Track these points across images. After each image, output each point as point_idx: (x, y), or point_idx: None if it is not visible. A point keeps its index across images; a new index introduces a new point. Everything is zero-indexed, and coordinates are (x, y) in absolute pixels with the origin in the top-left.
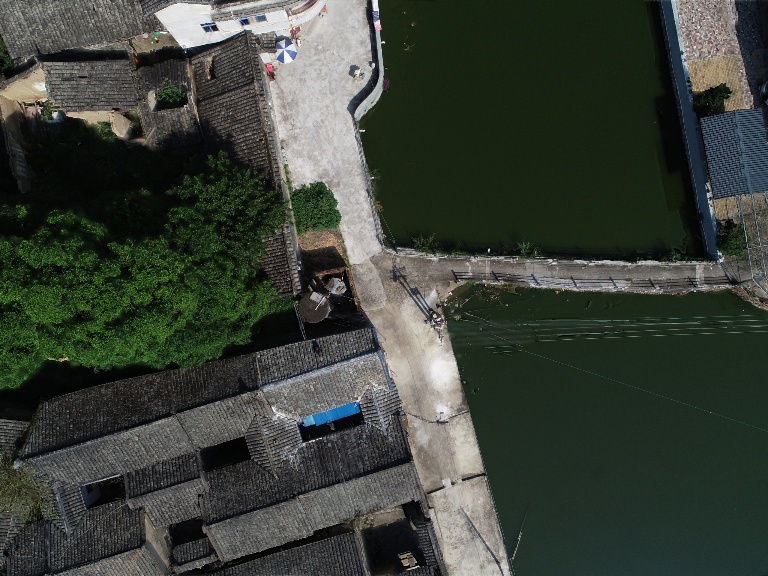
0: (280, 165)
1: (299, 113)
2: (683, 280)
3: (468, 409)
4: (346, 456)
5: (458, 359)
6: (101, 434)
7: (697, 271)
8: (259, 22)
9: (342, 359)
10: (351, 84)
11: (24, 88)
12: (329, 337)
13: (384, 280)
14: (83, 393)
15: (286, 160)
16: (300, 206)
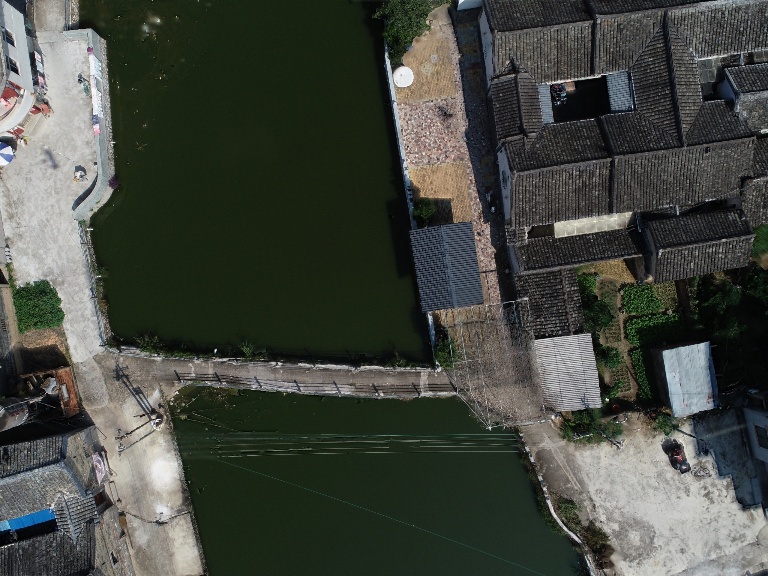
0: None
1: (24, 211)
2: (407, 386)
3: (189, 510)
4: (33, 564)
5: (186, 458)
6: None
7: (421, 378)
8: None
9: (27, 468)
10: (76, 184)
11: None
12: (21, 444)
13: (107, 379)
14: None
15: (9, 258)
16: (22, 304)
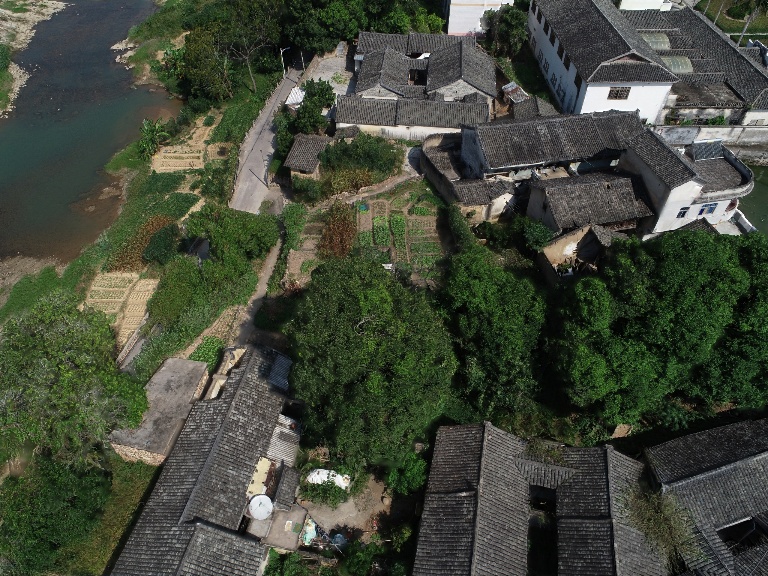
0: None
1: None
2: None
3: None
4: None
5: None
6: (730, 462)
7: None
8: (707, 214)
9: None
10: None
11: (560, 248)
12: None
13: None
14: (680, 441)
15: None
16: None
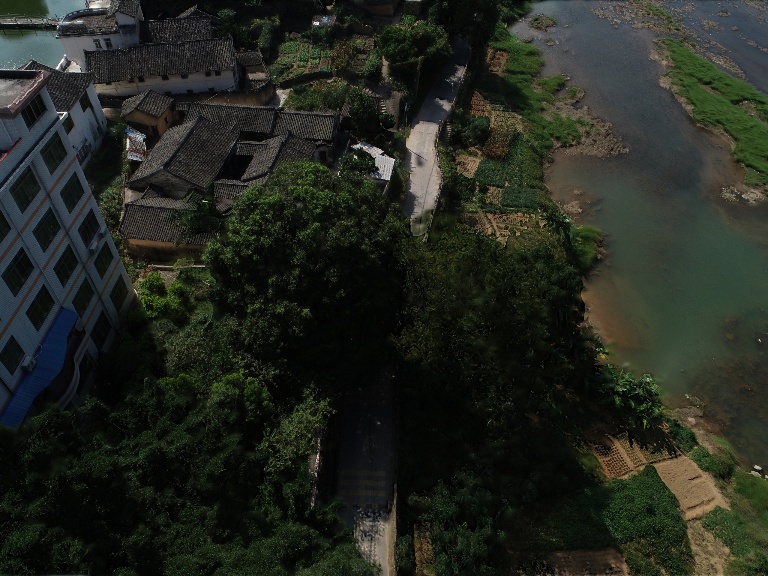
0: None
1: None
2: None
3: None
4: None
5: None
6: None
7: None
8: None
9: None
10: None
11: None
12: None
13: None
14: None
15: None
16: None
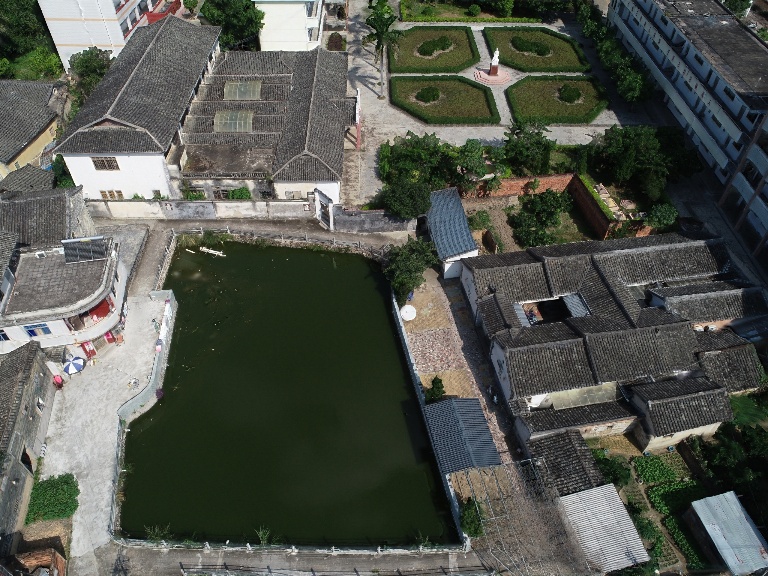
0: (30, 452)
1: (73, 415)
2: (435, 571)
3: None
4: None
5: None
6: None
7: (450, 560)
8: (46, 334)
9: None
10: (127, 392)
11: None
12: None
13: (102, 575)
14: None
15: (43, 453)
16: (39, 495)
